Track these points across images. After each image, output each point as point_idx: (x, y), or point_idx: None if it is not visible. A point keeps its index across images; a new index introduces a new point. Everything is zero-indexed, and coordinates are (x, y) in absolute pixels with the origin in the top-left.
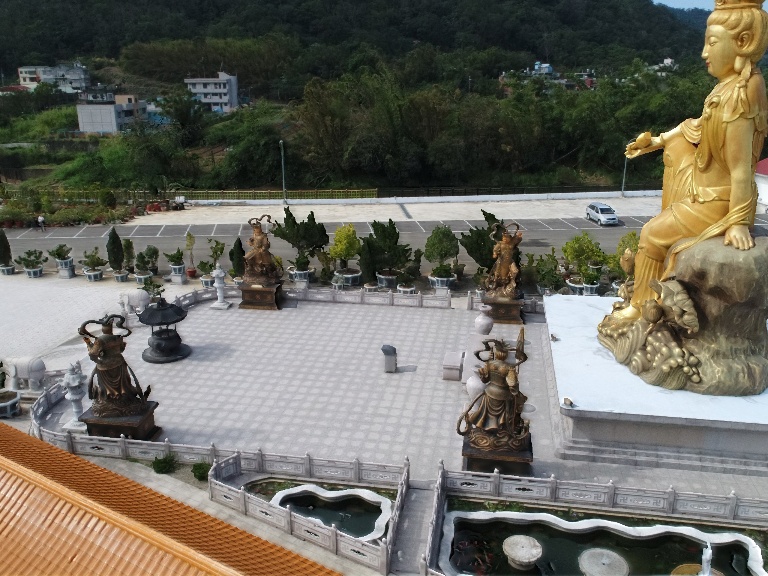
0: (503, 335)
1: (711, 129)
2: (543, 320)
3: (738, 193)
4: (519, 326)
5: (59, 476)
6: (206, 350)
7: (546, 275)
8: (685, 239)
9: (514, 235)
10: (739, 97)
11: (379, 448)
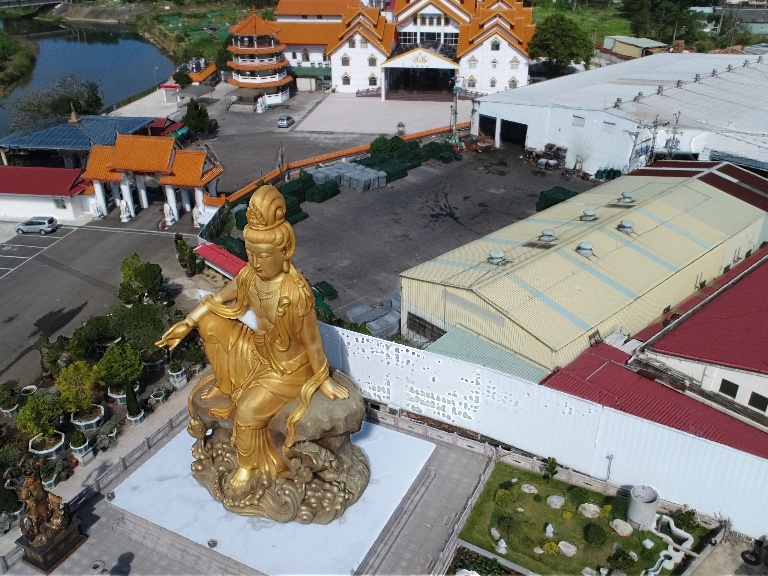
0: None
1: (288, 322)
2: (93, 517)
3: (321, 358)
4: (88, 544)
5: None
6: None
7: None
8: (289, 405)
9: (32, 467)
10: (306, 295)
11: None
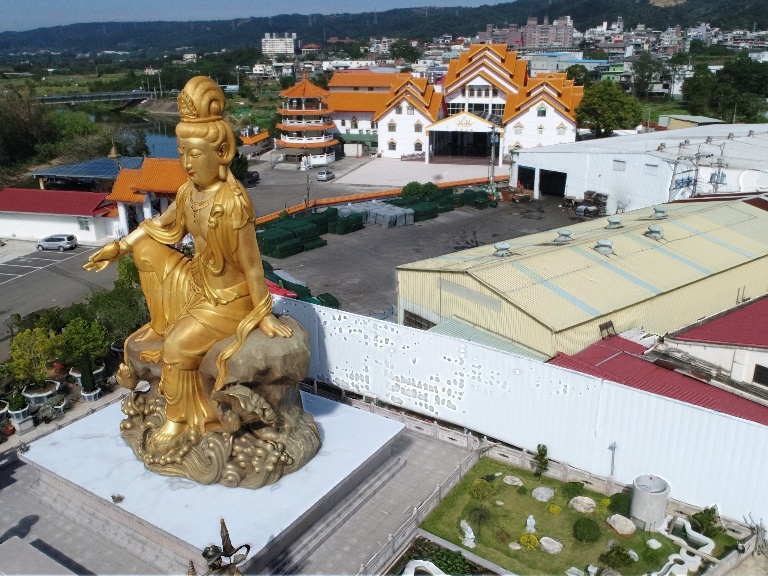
0: None
1: (221, 236)
2: (9, 480)
3: (261, 288)
4: None
5: None
6: None
7: None
8: (222, 342)
9: None
10: (242, 205)
11: None
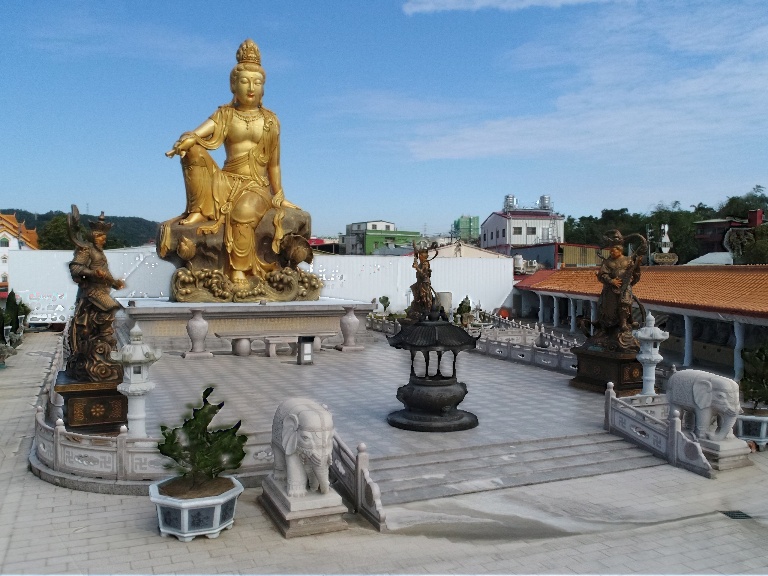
0: None
1: None
2: None
3: None
4: None
5: (706, 282)
6: (380, 410)
7: None
8: None
9: None
10: None
11: (443, 356)
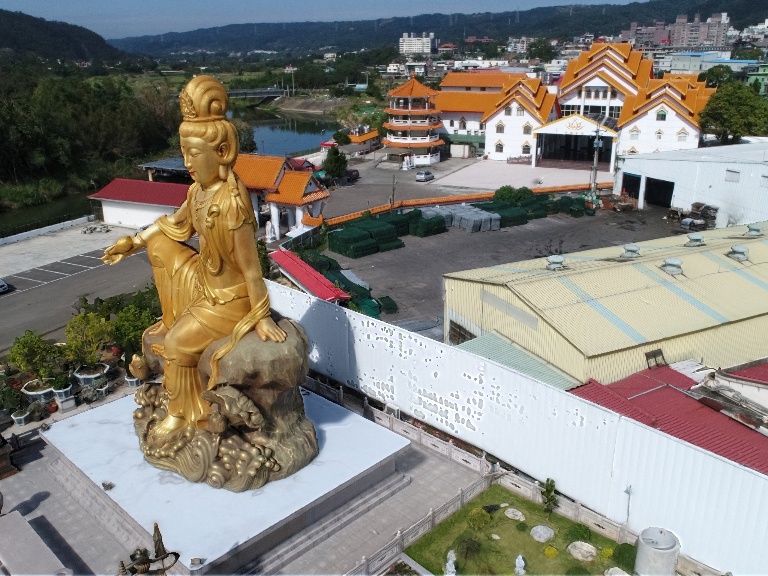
0: (7, 499)
1: (217, 236)
2: (37, 455)
3: (257, 290)
4: (16, 477)
5: None
6: None
7: (6, 398)
8: (218, 342)
9: None
10: (238, 206)
11: None
